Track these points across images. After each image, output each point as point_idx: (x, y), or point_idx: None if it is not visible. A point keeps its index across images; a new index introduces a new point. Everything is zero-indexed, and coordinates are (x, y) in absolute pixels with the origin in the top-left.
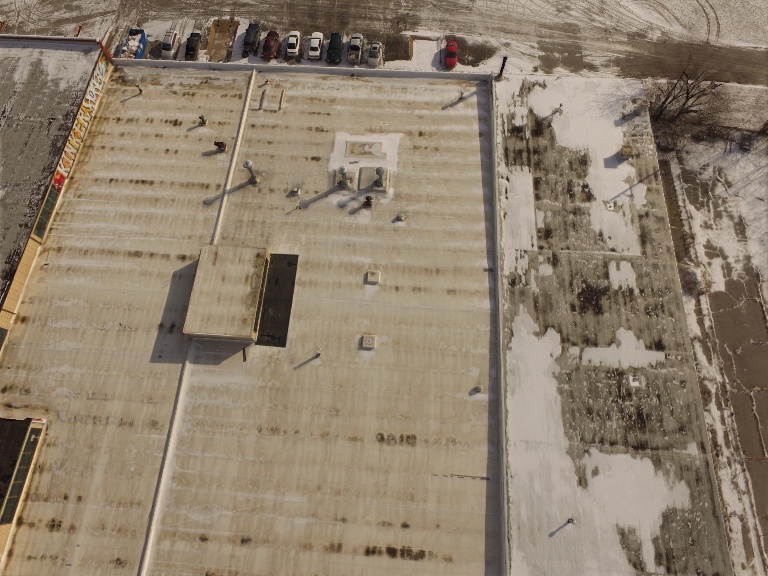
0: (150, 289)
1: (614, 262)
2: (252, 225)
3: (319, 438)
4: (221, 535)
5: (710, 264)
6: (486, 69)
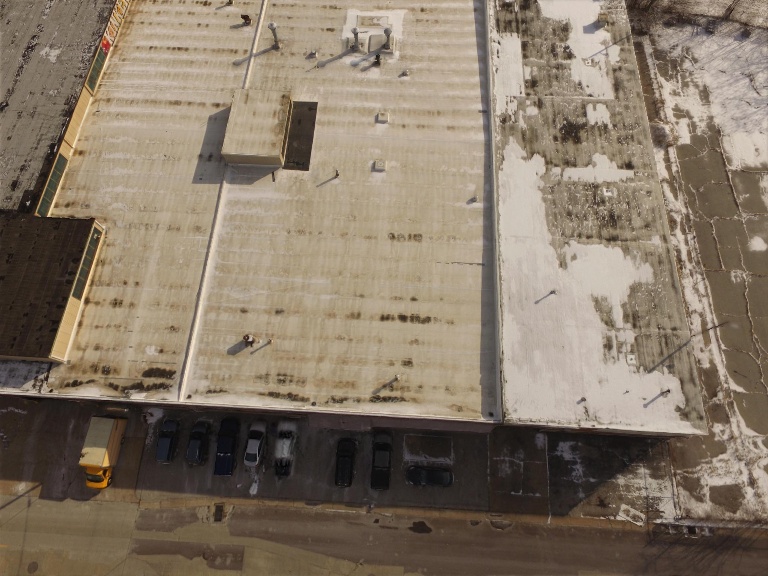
0: (190, 128)
1: (591, 104)
2: (276, 80)
3: (339, 237)
4: (258, 308)
5: (678, 123)
6: None
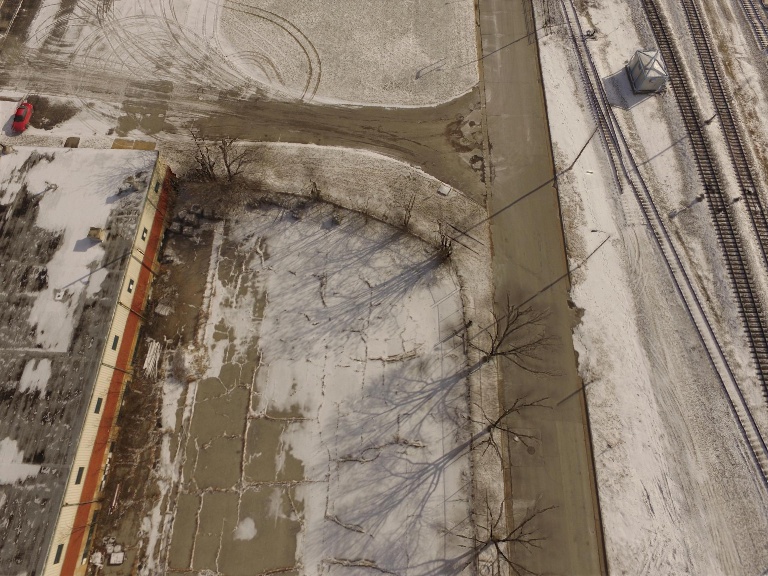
0: None
1: (34, 360)
2: None
3: None
4: None
5: (214, 347)
6: (58, 132)
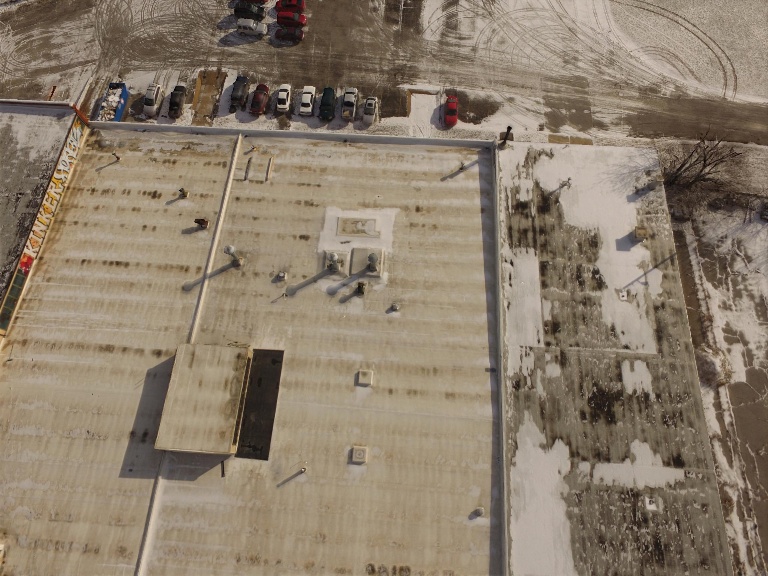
0: (122, 390)
1: (628, 361)
2: (234, 315)
3: (303, 569)
4: None
5: (730, 351)
6: (488, 127)
